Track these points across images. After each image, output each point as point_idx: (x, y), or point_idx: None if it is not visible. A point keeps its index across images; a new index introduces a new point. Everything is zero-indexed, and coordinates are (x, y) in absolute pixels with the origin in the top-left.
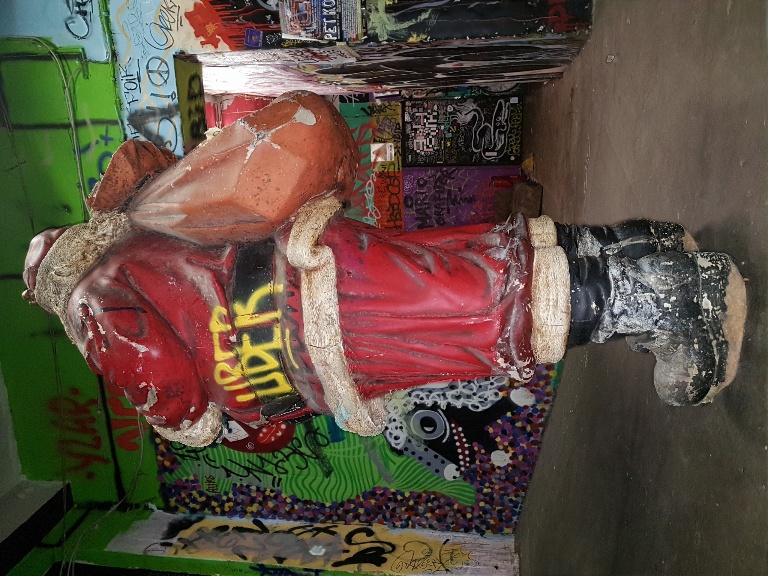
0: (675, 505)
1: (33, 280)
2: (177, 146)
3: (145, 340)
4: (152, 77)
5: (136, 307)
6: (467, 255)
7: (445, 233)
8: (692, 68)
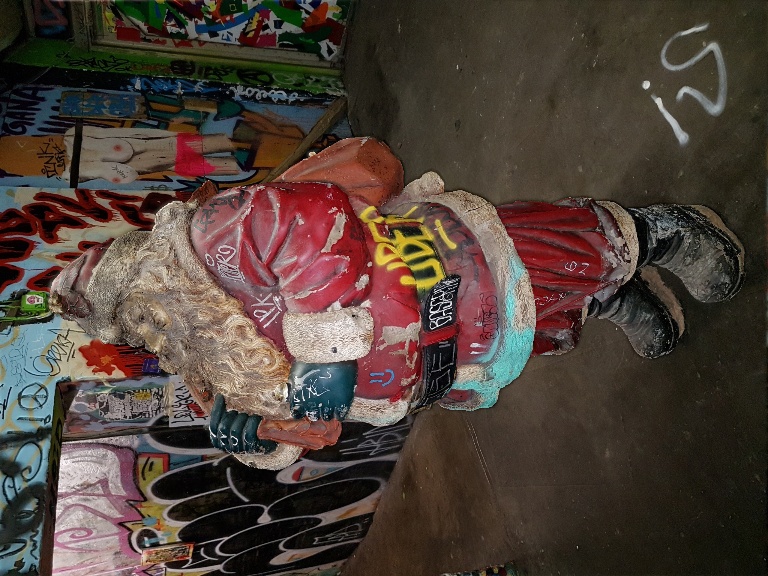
0: None
1: (96, 258)
2: (39, 472)
3: None
4: (25, 402)
5: None
6: None
7: None
8: None
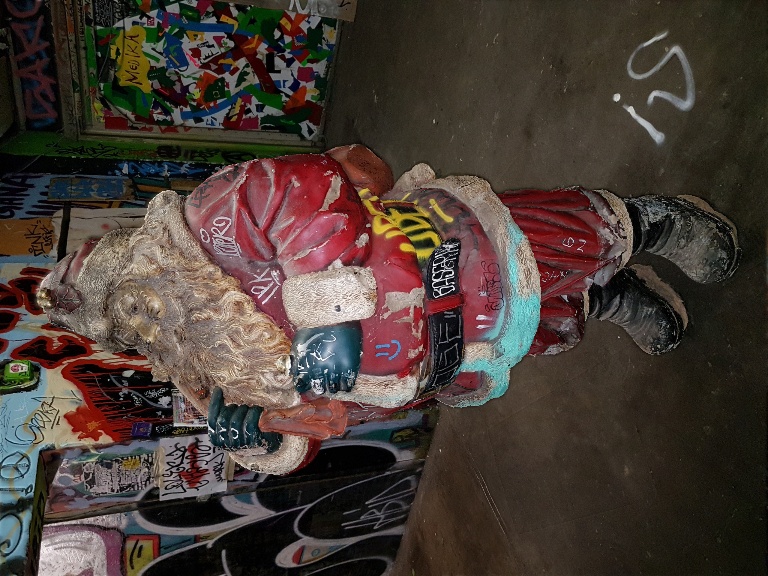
0: None
1: (87, 251)
2: (19, 545)
3: None
4: (5, 473)
5: None
6: None
7: None
8: None
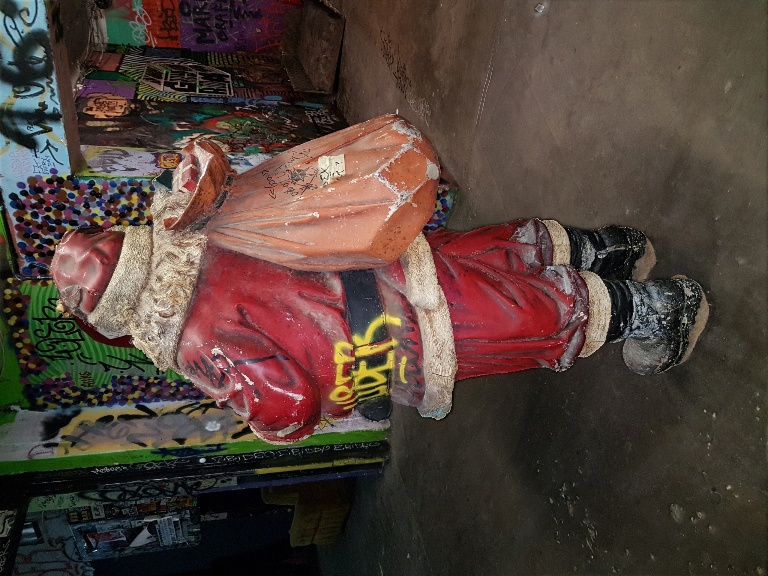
0: (603, 419)
1: (92, 304)
2: (38, 16)
3: (300, 389)
4: None
5: (277, 355)
6: (537, 284)
7: (487, 241)
8: (669, 104)
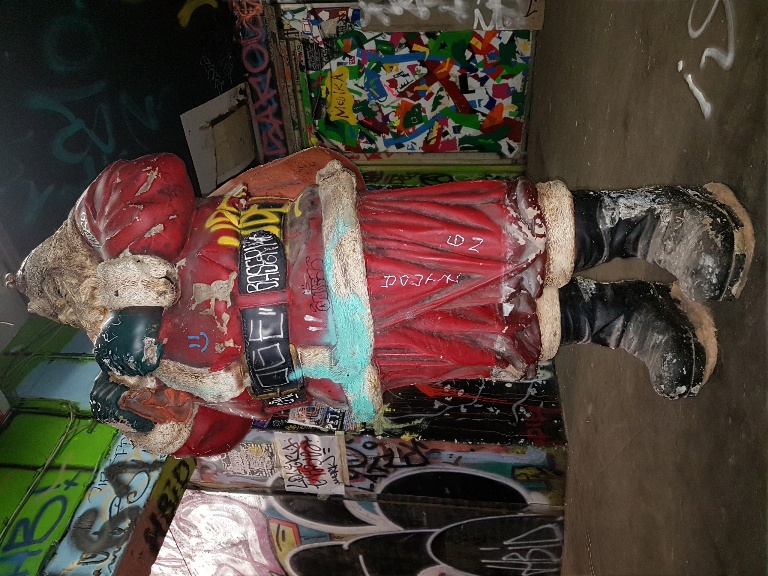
0: None
1: None
2: (141, 497)
3: None
4: None
5: None
6: None
7: None
8: None
